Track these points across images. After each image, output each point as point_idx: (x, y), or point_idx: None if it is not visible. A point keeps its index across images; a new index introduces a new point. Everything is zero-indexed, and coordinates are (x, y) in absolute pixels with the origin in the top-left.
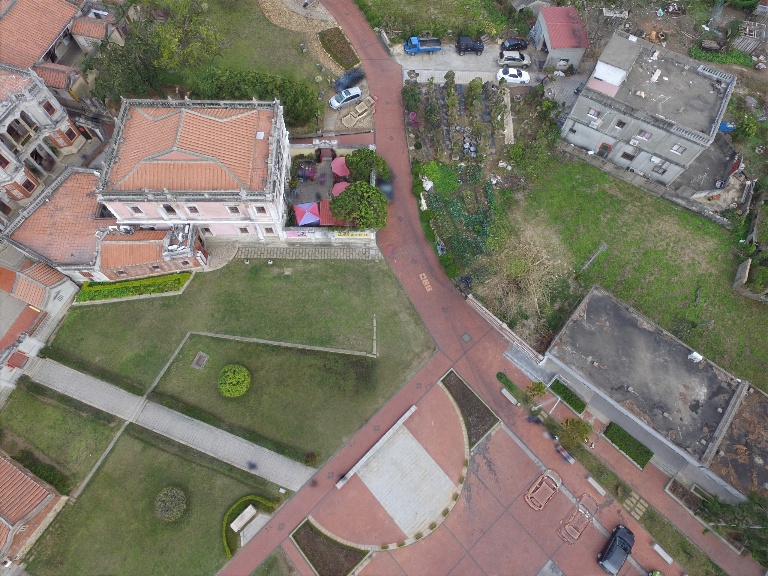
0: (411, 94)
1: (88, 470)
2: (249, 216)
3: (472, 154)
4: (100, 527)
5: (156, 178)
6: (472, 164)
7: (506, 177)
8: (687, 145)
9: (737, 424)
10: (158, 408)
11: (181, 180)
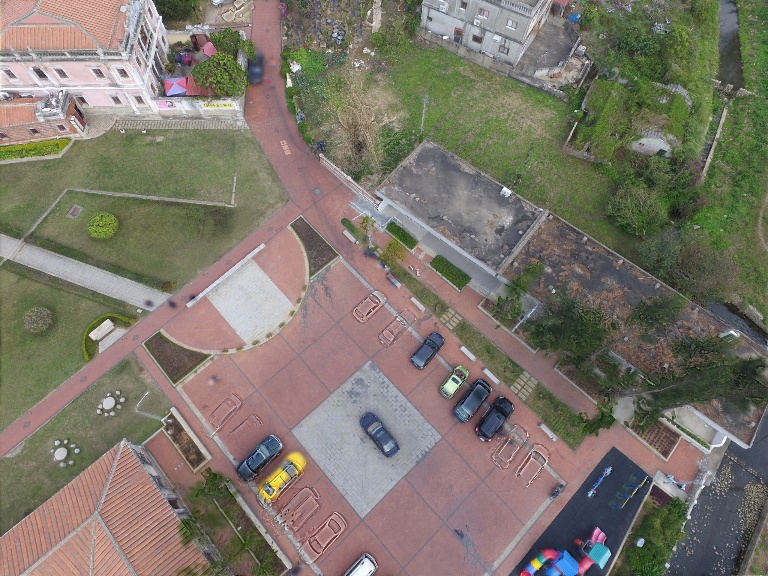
0: None
1: None
2: (115, 81)
3: (339, 42)
4: None
5: (23, 41)
6: (339, 51)
7: (369, 61)
8: (517, 19)
9: (534, 243)
10: (34, 249)
11: (45, 42)
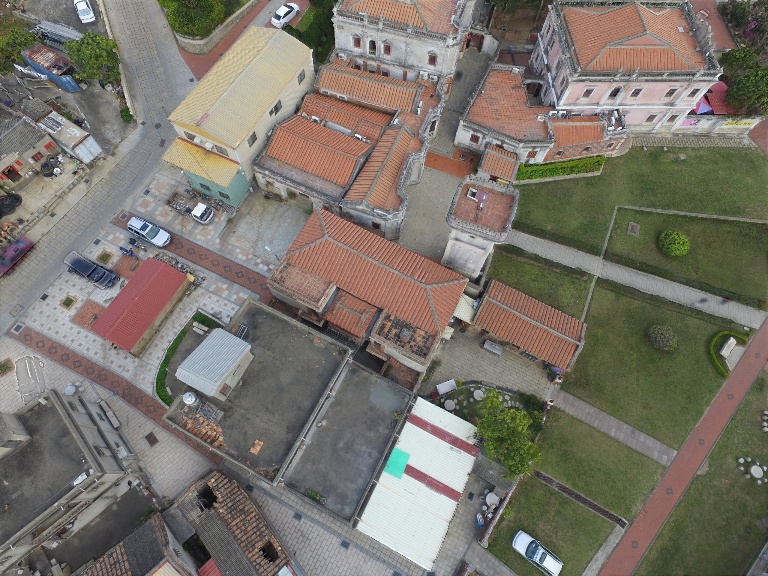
0: (742, 7)
1: (580, 313)
2: (674, 101)
3: None
4: (606, 357)
5: (619, 61)
6: None
7: None
8: None
9: None
10: (615, 266)
11: (641, 63)
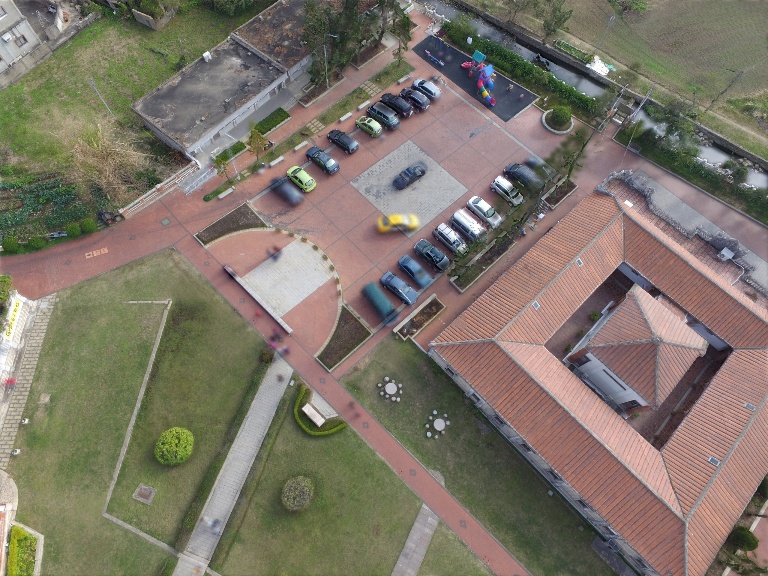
0: None
1: None
2: None
3: None
4: (318, 572)
5: None
6: None
7: None
8: None
9: (260, 48)
10: (196, 535)
11: None
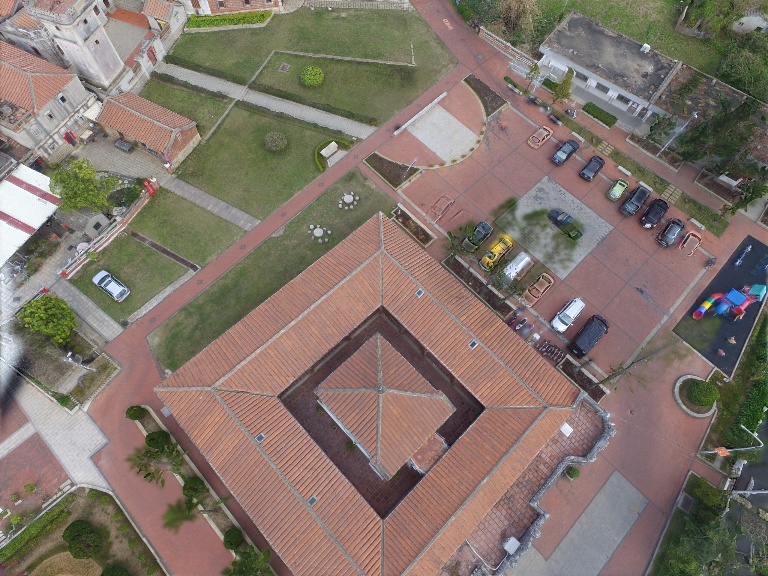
0: None
1: (212, 125)
2: None
3: None
4: (226, 157)
5: None
6: None
7: None
8: None
9: (674, 84)
10: (257, 93)
11: None
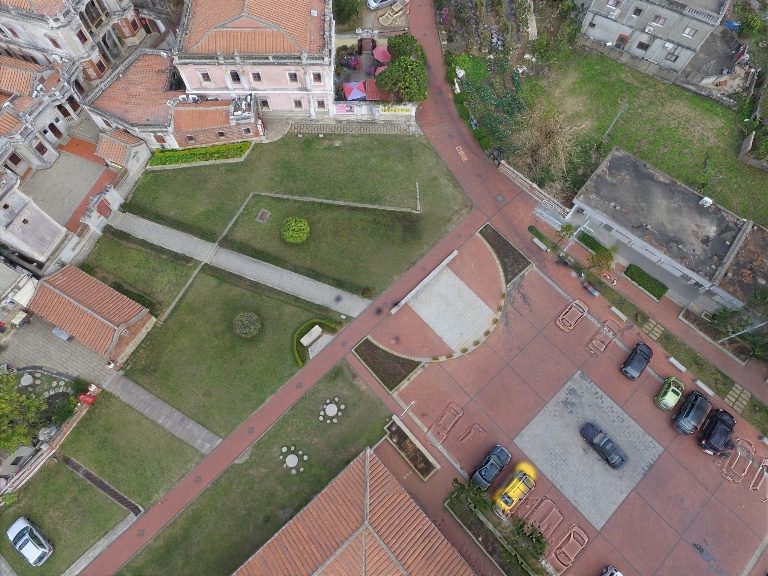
0: None
1: (172, 300)
2: (305, 86)
3: (500, 48)
4: (186, 344)
5: (225, 44)
6: (500, 56)
7: (531, 67)
8: (698, 26)
9: (743, 254)
10: (229, 253)
11: (248, 46)
